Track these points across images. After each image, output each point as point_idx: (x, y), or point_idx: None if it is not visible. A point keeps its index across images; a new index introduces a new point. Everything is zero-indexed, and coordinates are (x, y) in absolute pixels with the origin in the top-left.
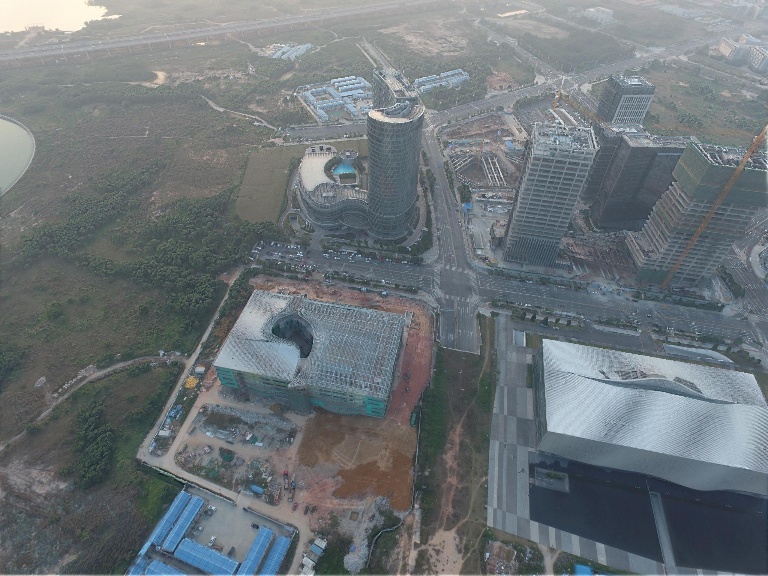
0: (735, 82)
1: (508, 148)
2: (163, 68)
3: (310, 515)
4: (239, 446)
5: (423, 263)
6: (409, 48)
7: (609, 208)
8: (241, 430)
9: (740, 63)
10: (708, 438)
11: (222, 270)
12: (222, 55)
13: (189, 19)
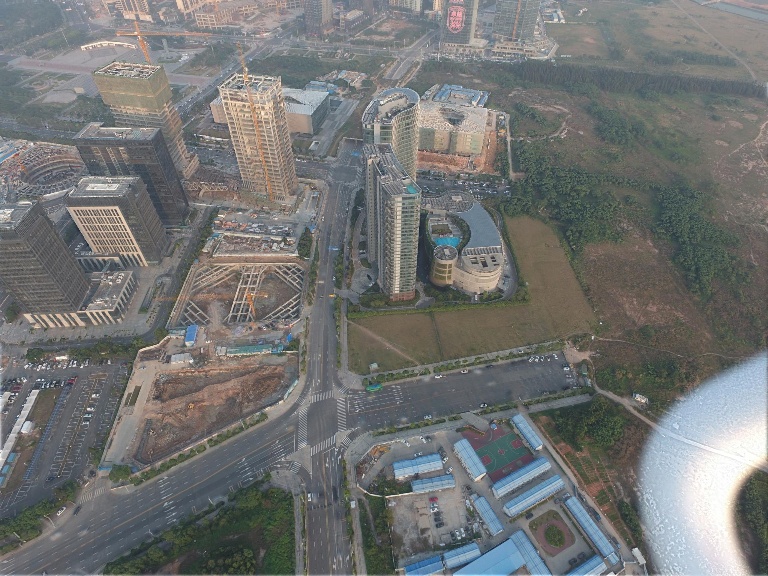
0: None
1: None
2: None
3: None
4: None
5: None
6: None
7: None
8: None
9: None
10: None
11: None
12: None
13: None
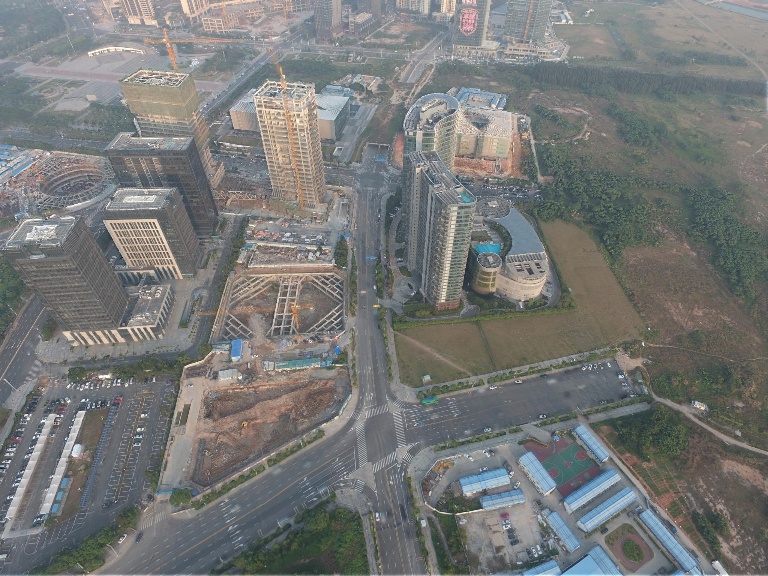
0: None
1: None
2: None
3: None
4: None
5: None
6: None
7: None
8: None
9: None
10: None
11: None
12: None
13: None
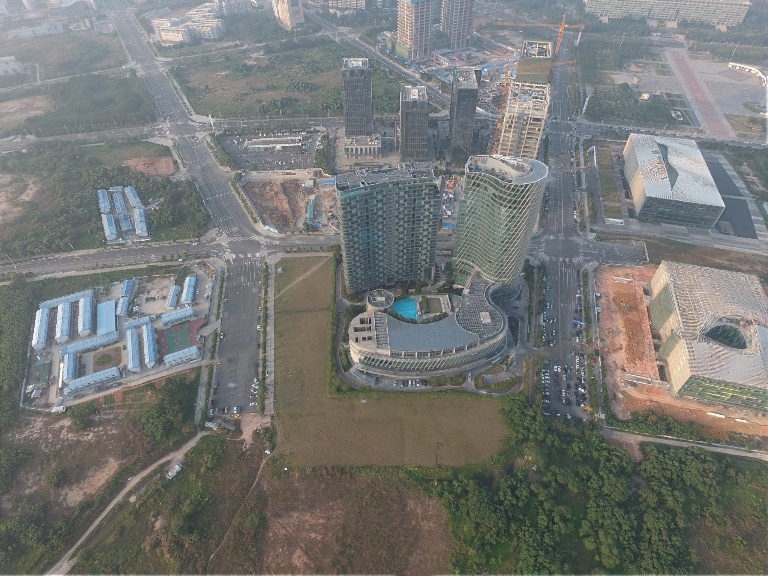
0: (231, 54)
1: None
2: None
3: None
4: None
5: None
6: None
7: None
8: None
9: (199, 41)
10: (690, 156)
11: None
12: None
13: None
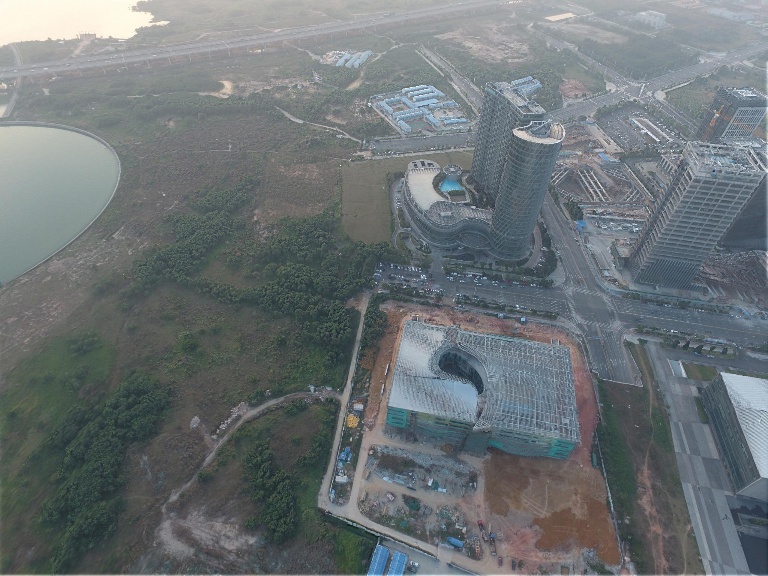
0: None
1: (603, 161)
2: (228, 77)
3: (519, 571)
4: (422, 492)
5: (552, 286)
6: (472, 55)
7: (736, 226)
8: (419, 474)
9: None
10: None
11: (349, 296)
12: (284, 63)
13: (240, 25)
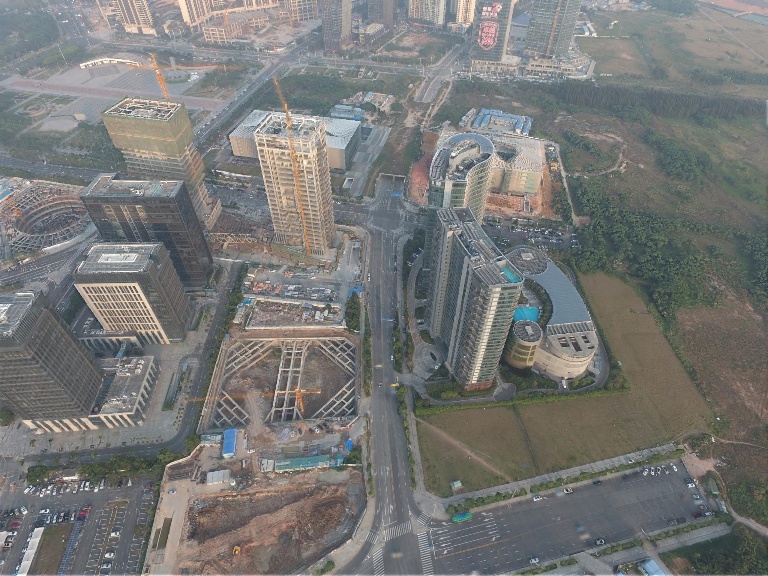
0: None
1: None
2: None
3: None
4: None
5: None
6: None
7: None
8: None
9: None
10: None
11: None
12: None
13: None
